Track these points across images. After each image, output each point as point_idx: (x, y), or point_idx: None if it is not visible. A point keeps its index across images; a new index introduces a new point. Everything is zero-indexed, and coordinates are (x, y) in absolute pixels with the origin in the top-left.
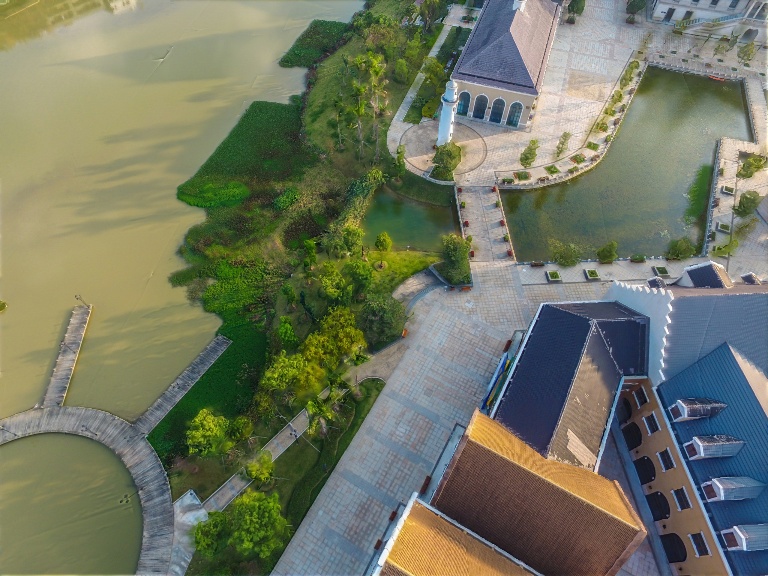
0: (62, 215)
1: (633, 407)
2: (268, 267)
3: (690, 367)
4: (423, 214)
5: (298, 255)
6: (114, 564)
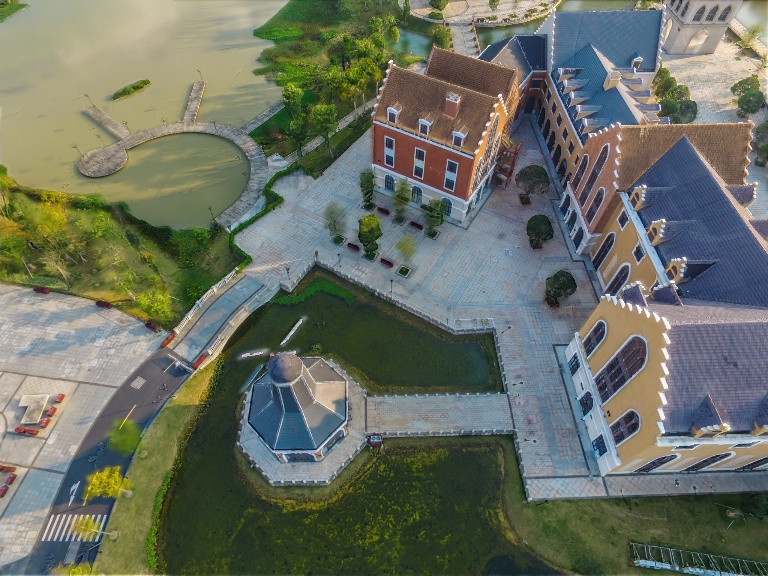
0: (178, 43)
1: (542, 99)
2: (318, 66)
3: (569, 59)
4: (422, 41)
5: (337, 61)
6: (236, 178)
